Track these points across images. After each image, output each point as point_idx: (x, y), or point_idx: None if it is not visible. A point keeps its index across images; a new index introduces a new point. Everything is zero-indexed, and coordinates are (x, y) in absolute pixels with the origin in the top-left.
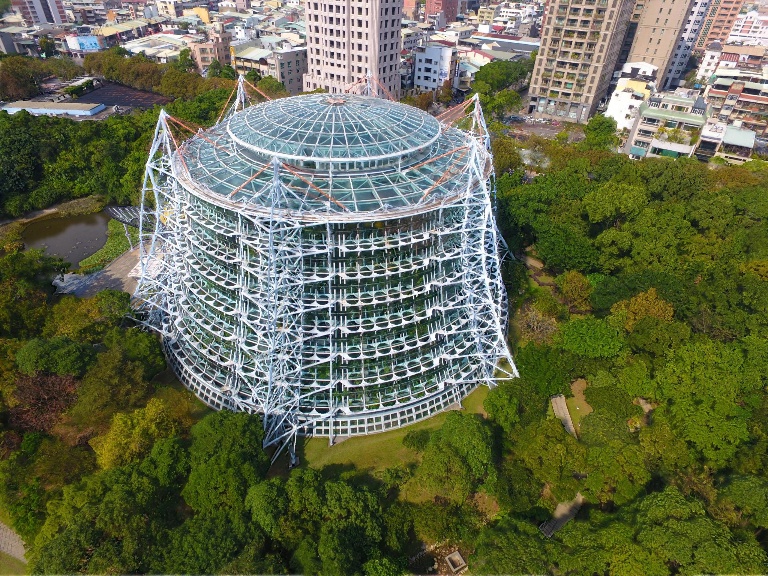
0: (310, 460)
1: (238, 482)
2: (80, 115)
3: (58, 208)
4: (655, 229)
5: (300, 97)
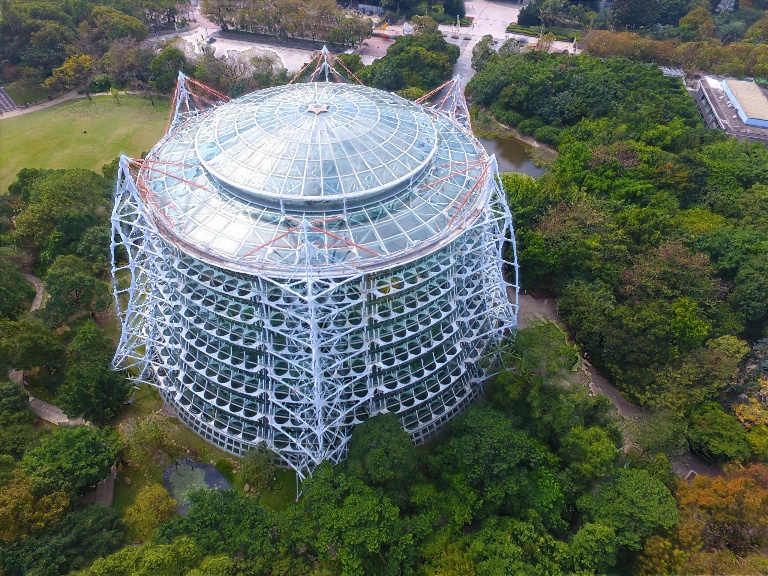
0: None
1: None
2: (739, 118)
3: (539, 146)
4: None
5: (362, 99)
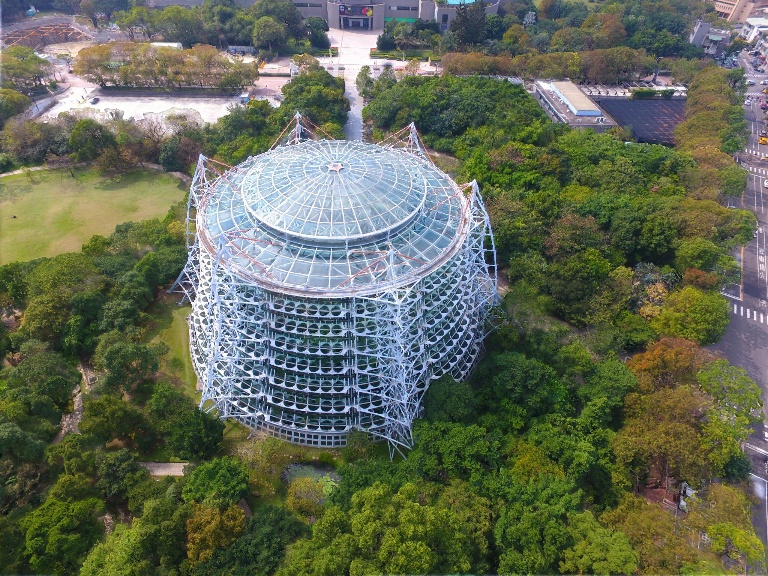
0: (179, 310)
1: (139, 265)
2: (571, 111)
3: (440, 156)
4: (322, 568)
5: (358, 153)
